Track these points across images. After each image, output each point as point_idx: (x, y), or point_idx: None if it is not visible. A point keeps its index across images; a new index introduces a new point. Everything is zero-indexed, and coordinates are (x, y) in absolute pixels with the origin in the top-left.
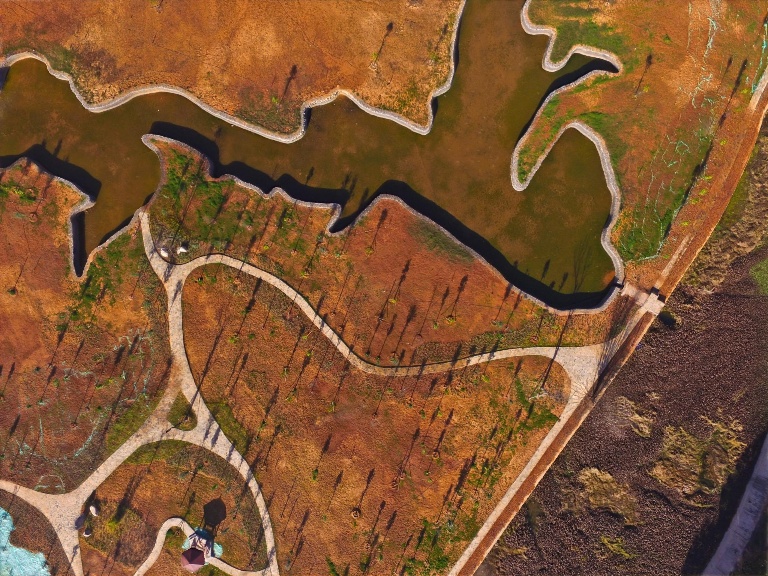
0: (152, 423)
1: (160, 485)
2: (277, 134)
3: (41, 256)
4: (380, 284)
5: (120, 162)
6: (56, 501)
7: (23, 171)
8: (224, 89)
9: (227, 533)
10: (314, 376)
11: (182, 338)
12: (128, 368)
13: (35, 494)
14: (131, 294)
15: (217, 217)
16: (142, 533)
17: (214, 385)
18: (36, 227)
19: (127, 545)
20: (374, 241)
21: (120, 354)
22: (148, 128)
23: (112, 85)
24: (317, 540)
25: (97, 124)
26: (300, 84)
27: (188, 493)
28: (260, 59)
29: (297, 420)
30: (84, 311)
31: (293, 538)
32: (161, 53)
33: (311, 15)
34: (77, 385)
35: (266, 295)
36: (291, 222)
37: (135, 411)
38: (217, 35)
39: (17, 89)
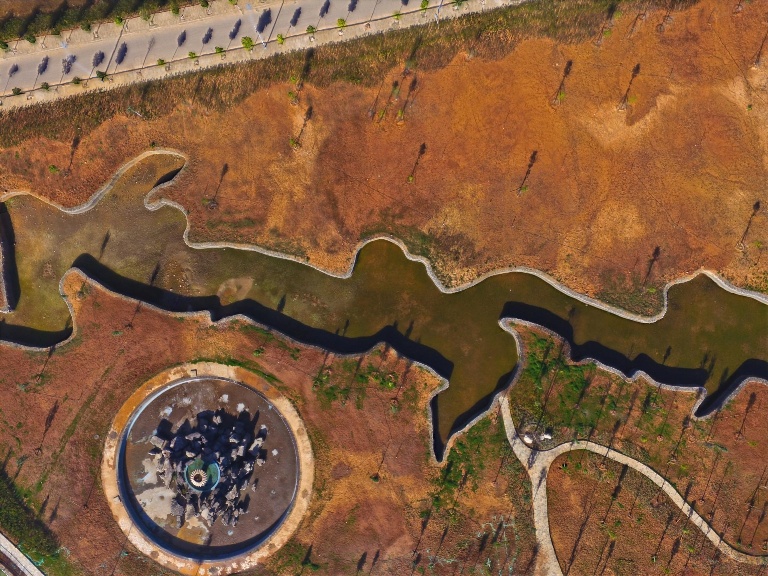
0: None
1: None
2: (640, 317)
3: (402, 442)
4: (750, 470)
5: (472, 343)
6: None
7: (382, 356)
8: (584, 271)
9: None
10: (683, 565)
11: (548, 526)
12: (493, 556)
13: None
14: (494, 480)
15: (580, 402)
16: None
17: (581, 574)
18: (397, 413)
19: None
20: (743, 426)
21: (484, 541)
22: (500, 308)
23: (470, 269)
24: None
25: (449, 305)
26: (663, 266)
27: None
28: (622, 241)
29: None
30: (446, 497)
31: None
32: (520, 236)
33: (676, 196)
34: (442, 573)
35: (633, 482)
36: (656, 407)
37: None
38: (577, 217)
39: (368, 270)
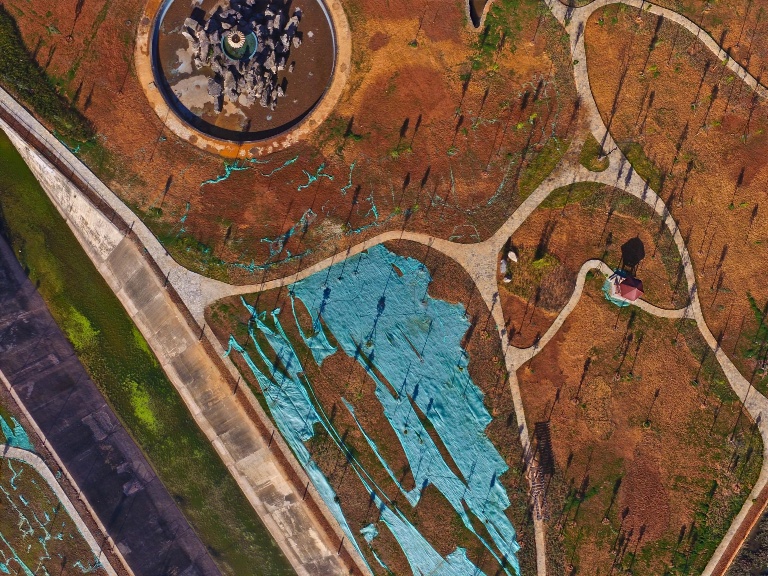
0: (564, 166)
1: (575, 228)
2: None
3: (439, 8)
4: None
5: None
6: (472, 250)
7: None
8: None
9: (646, 272)
10: (723, 110)
11: (587, 80)
12: None
13: (450, 244)
14: (532, 40)
15: None
16: (561, 277)
17: (623, 125)
18: None
19: (547, 290)
20: None
21: (525, 100)
22: None
23: None
24: (736, 275)
25: None
26: None
27: (604, 234)
28: None
29: (708, 155)
30: (485, 60)
31: (712, 274)
32: None
33: None
34: (485, 133)
35: (669, 32)
36: None
37: (546, 155)
38: None
39: None
